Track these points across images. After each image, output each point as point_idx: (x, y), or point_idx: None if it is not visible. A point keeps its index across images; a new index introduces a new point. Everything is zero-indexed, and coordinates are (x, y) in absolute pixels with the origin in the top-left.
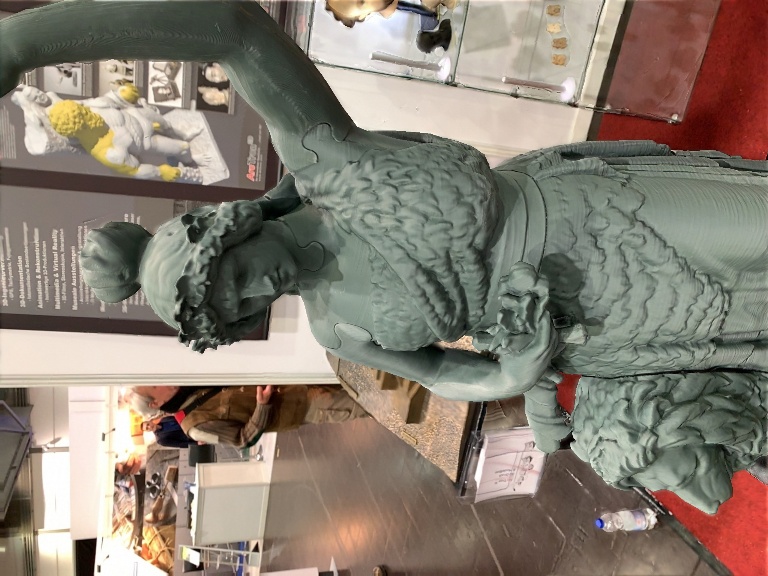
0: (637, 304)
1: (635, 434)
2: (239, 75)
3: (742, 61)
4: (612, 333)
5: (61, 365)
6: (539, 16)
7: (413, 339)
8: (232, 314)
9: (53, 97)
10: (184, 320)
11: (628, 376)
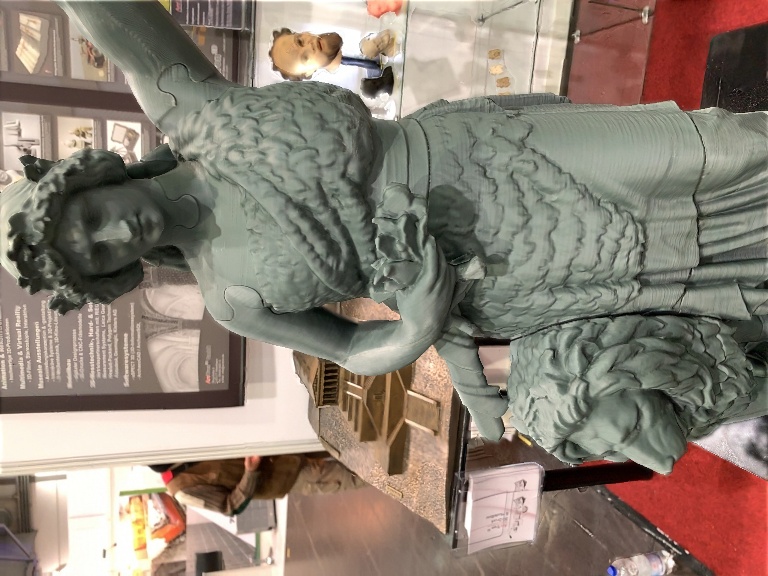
0: (540, 236)
1: (564, 385)
2: (77, 11)
3: (679, 80)
4: (519, 271)
5: (29, 450)
6: (485, 66)
7: (299, 289)
8: (85, 261)
9: (13, 175)
10: (22, 261)
11: (551, 326)
